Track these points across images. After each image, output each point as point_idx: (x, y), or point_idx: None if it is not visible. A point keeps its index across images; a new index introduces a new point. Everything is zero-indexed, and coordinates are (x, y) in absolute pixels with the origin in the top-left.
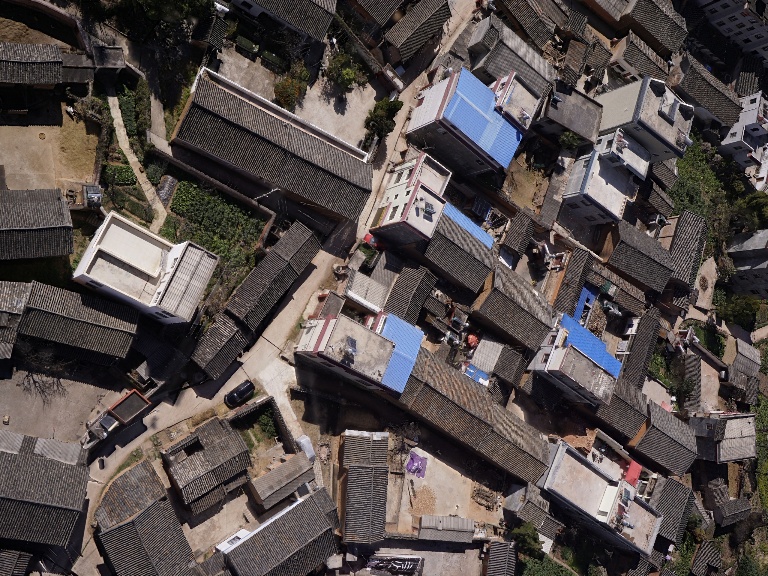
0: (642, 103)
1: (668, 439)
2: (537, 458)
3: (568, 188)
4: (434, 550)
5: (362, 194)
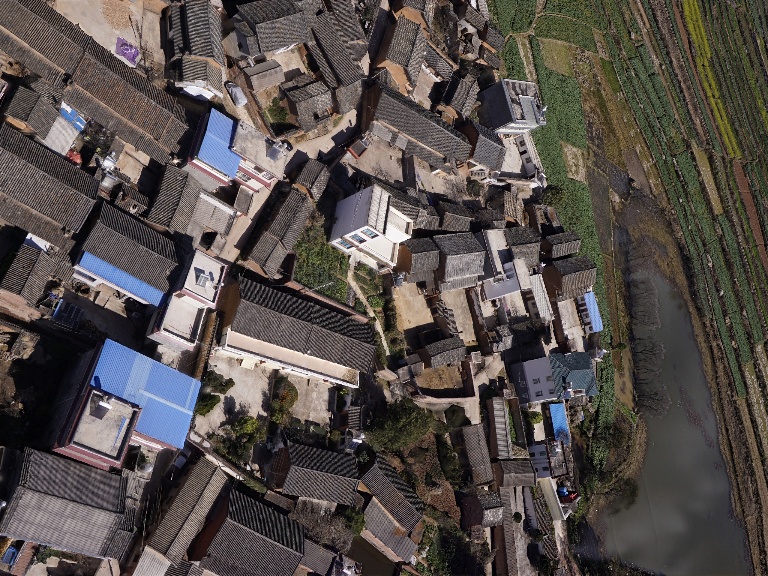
0: None
1: None
2: None
3: None
4: None
5: (246, 298)
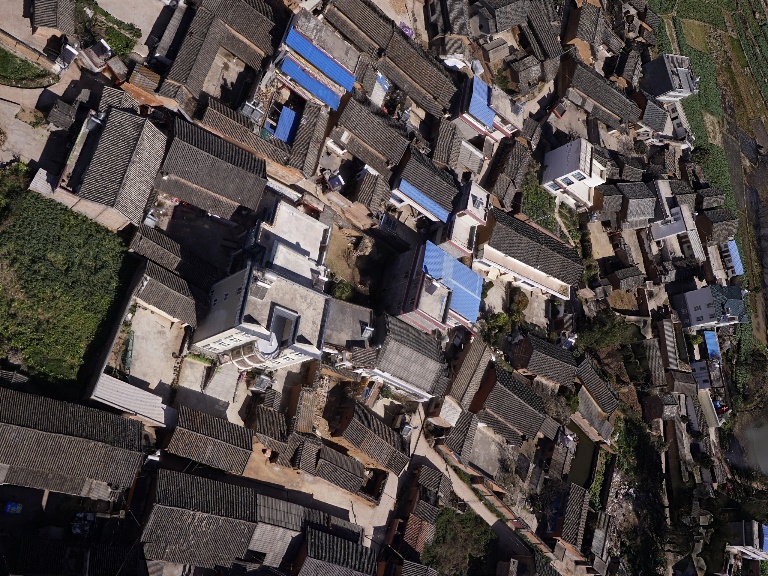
0: (326, 320)
1: None
2: None
3: None
4: None
5: None
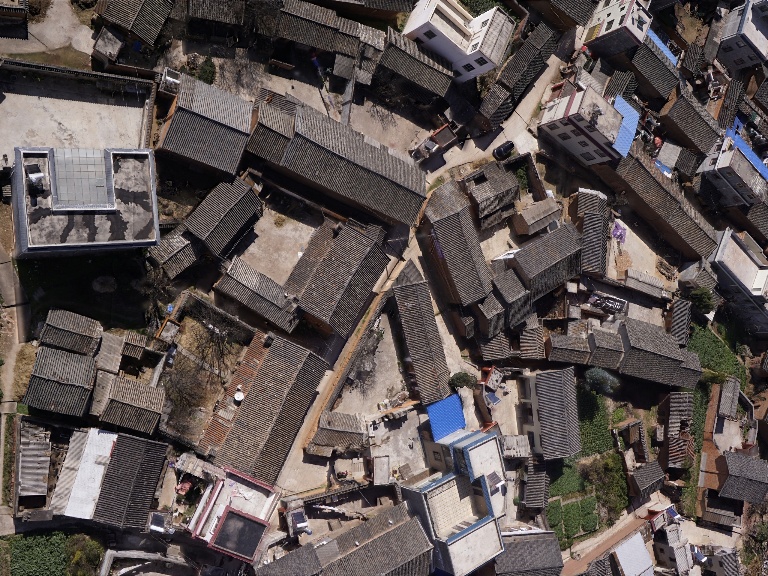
0: None
1: None
2: (710, 237)
3: (724, 33)
4: (632, 302)
5: (591, 4)
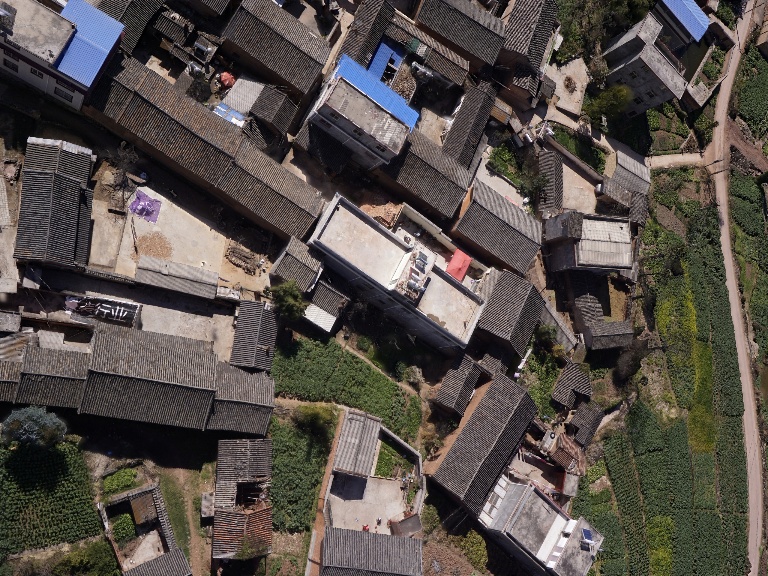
0: None
1: (498, 222)
2: (301, 206)
3: None
4: (167, 307)
5: None
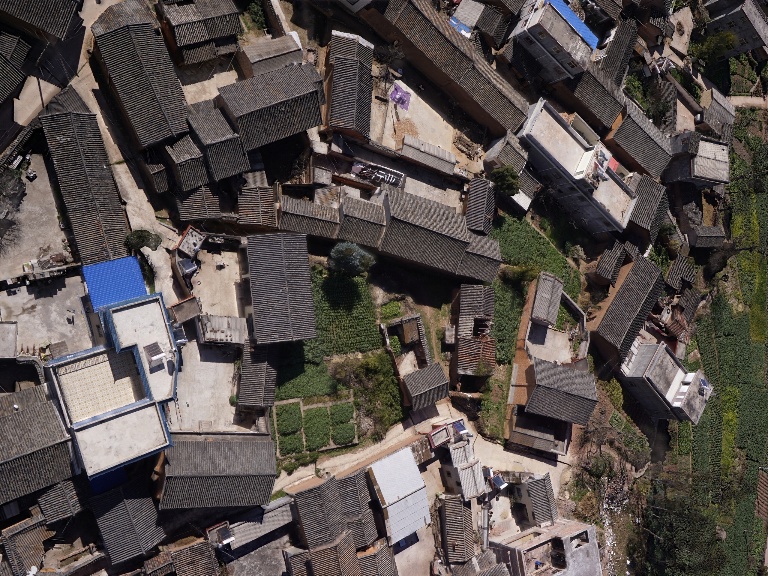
0: None
1: (643, 134)
2: (516, 106)
3: None
4: (416, 179)
5: None
